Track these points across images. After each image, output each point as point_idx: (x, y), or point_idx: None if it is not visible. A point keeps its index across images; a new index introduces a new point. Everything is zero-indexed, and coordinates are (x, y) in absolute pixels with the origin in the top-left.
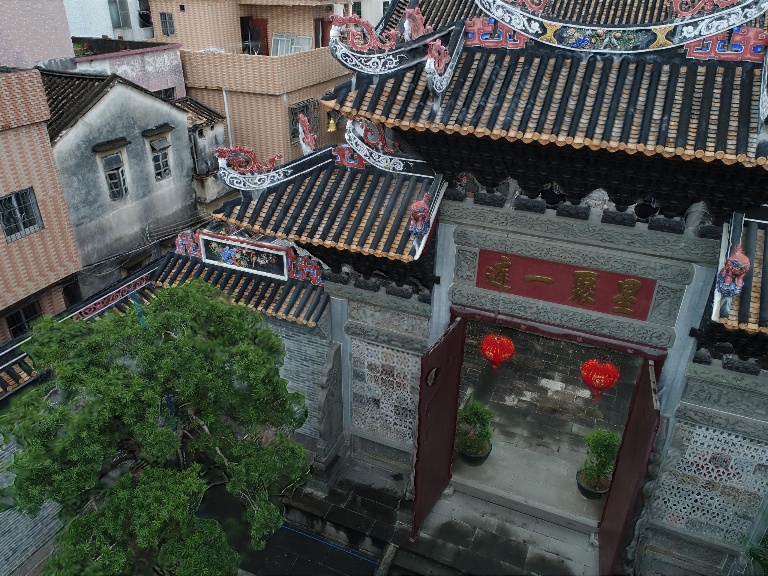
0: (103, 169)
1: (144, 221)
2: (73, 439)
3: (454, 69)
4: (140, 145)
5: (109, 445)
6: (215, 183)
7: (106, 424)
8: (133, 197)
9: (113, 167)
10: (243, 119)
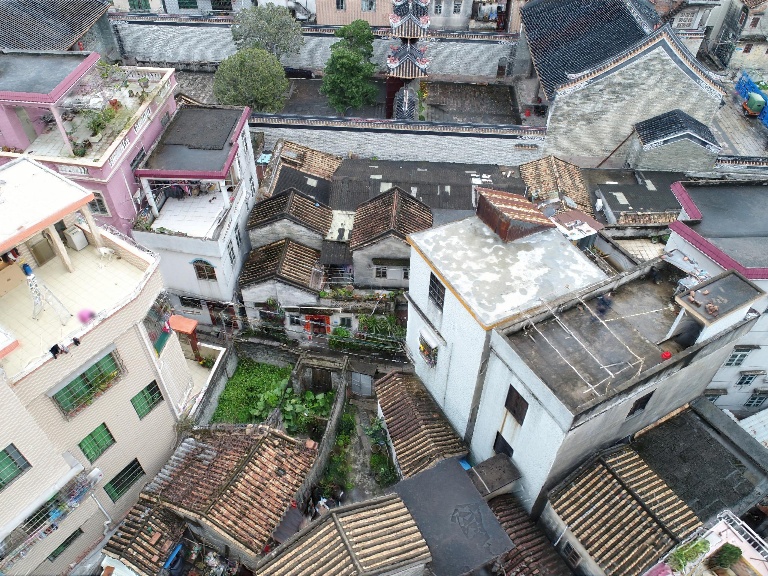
0: (435, 4)
1: (444, 24)
2: (340, 30)
3: (405, 2)
4: (450, 1)
5: (343, 34)
6: (475, 23)
7: (343, 30)
8: (443, 15)
9: (438, 4)
10: (514, 5)
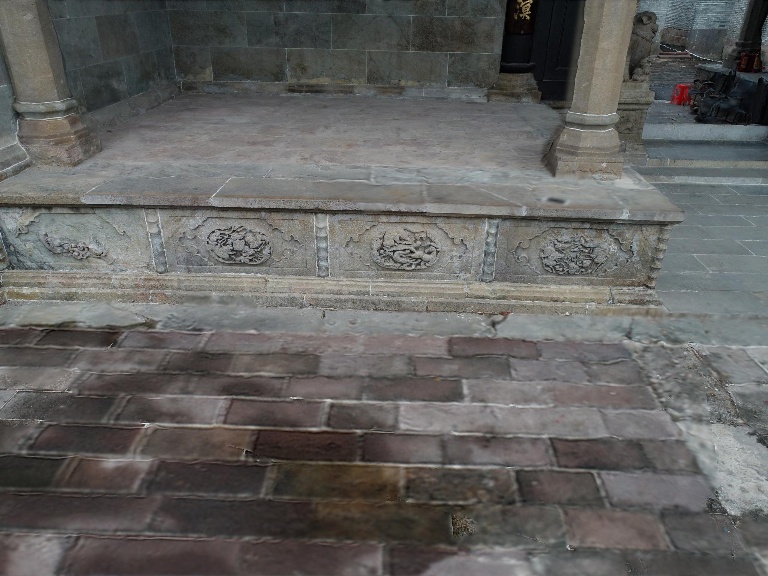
0: None
1: None
2: None
3: None
4: None
5: None
6: None
7: None
8: None
9: None
10: None
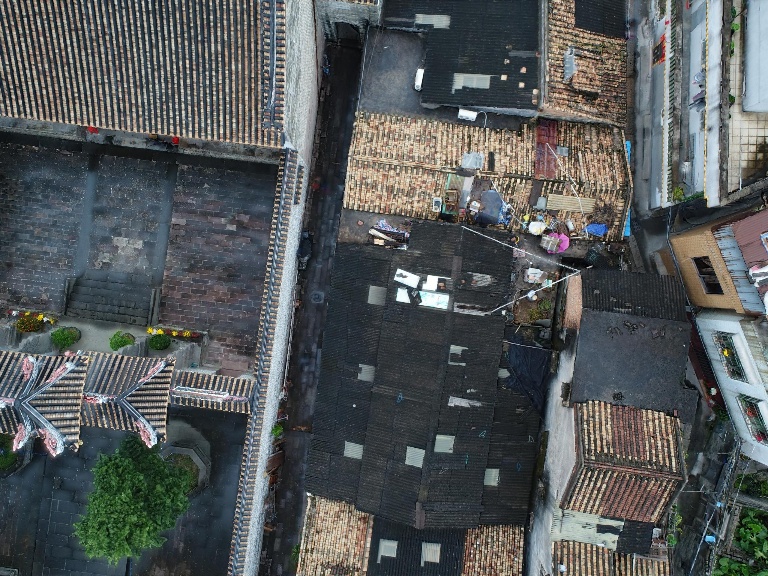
0: None
1: None
2: None
3: None
4: None
5: None
6: None
7: None
8: None
9: None
10: None
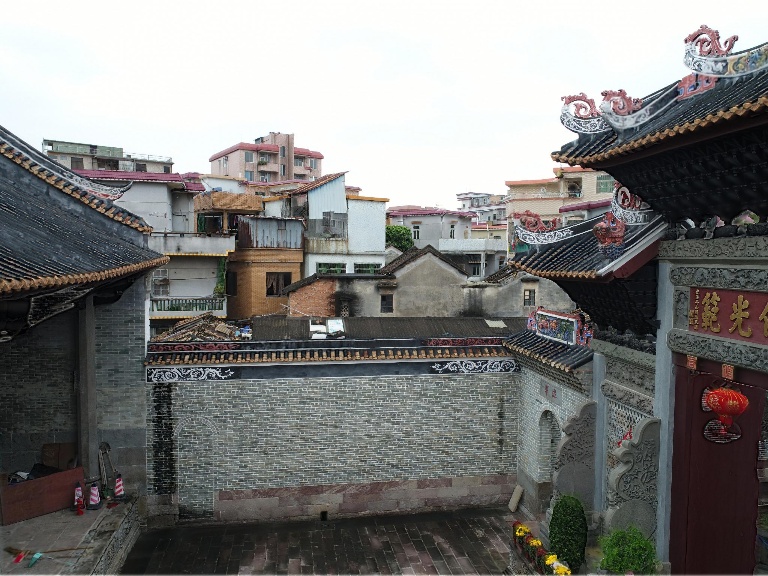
0: None
1: None
2: None
3: None
4: None
5: None
6: None
7: None
8: None
9: None
10: None
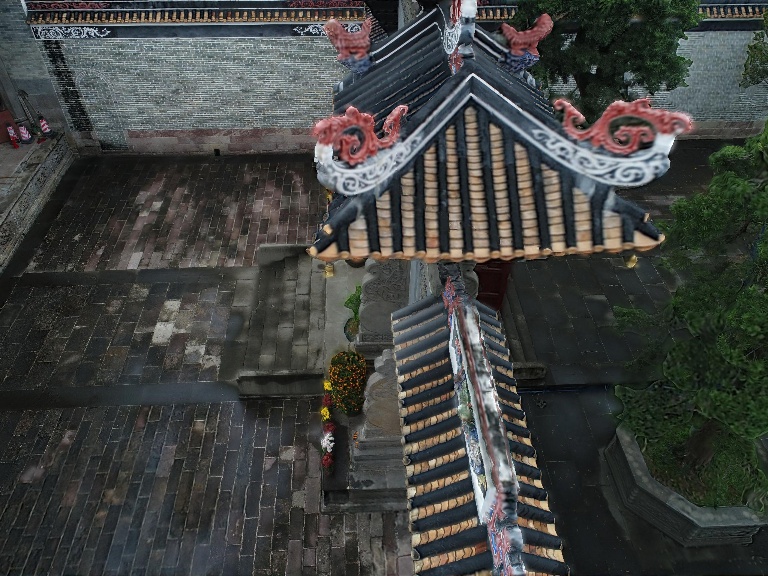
0: None
1: None
2: None
3: None
4: None
5: None
6: None
7: None
8: None
9: None
10: None
